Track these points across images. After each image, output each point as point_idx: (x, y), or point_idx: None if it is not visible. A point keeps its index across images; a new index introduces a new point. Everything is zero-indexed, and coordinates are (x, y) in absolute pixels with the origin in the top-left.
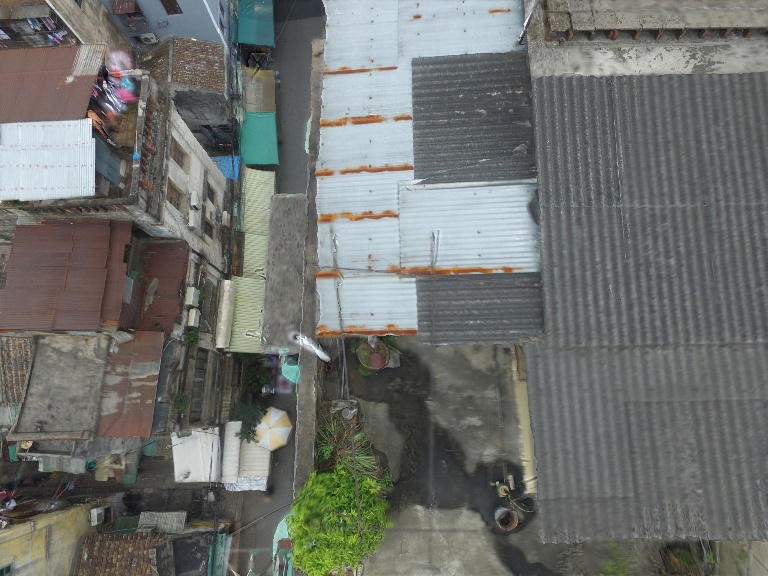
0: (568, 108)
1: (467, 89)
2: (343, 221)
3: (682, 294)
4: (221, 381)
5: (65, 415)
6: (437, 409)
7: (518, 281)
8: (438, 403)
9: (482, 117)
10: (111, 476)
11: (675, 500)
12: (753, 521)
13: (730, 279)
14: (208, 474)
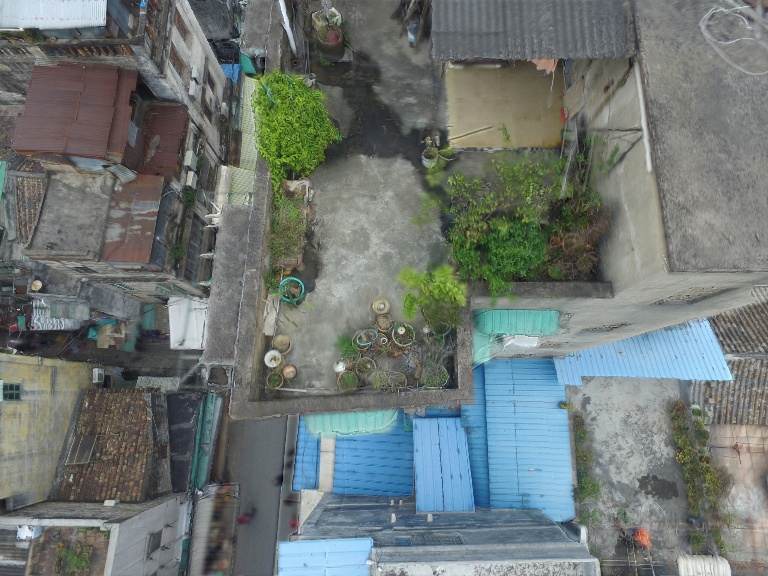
0: None
1: None
2: None
3: None
4: None
5: (73, 239)
6: (381, 92)
7: None
8: (382, 88)
9: None
10: (112, 344)
11: (533, 35)
12: (588, 46)
13: None
14: None
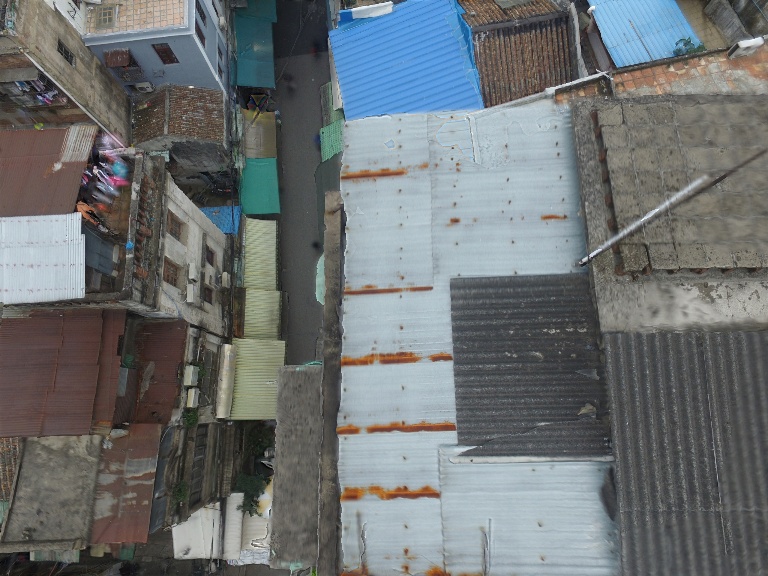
0: (650, 377)
1: (519, 323)
2: (372, 499)
3: None
4: (222, 452)
5: (55, 521)
6: None
7: None
8: None
9: (538, 363)
10: (107, 551)
11: None
12: None
13: None
14: (209, 551)
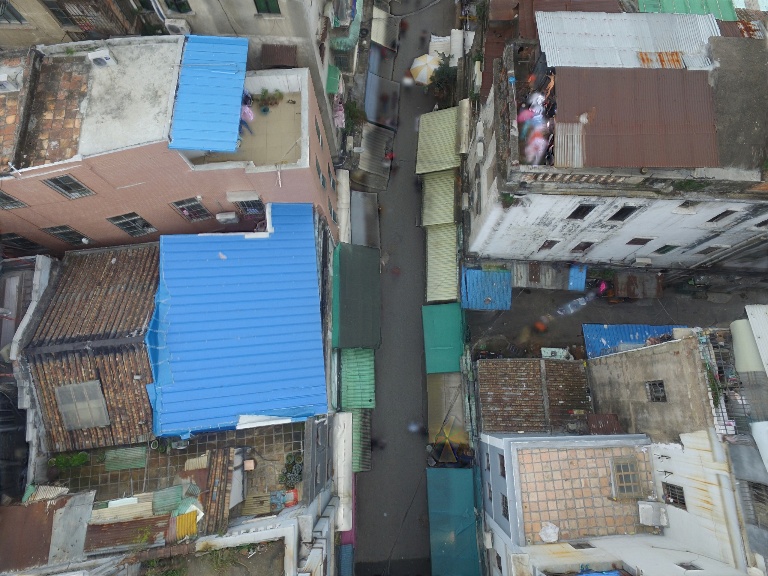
0: None
1: None
2: None
3: None
4: (465, 83)
5: None
6: None
7: None
8: None
9: None
10: None
11: None
12: None
13: None
14: (474, 34)
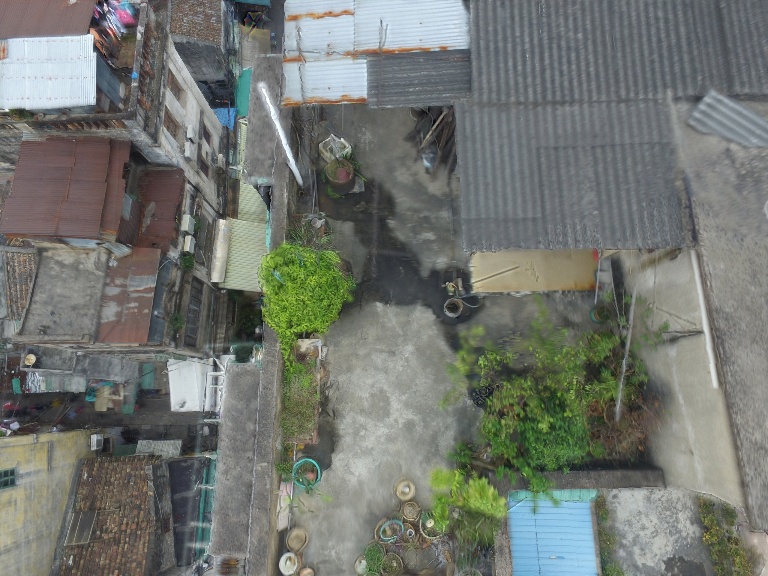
0: None
1: None
2: (307, 20)
3: (588, 63)
4: (216, 315)
5: (67, 321)
6: (396, 226)
7: (452, 57)
8: (397, 222)
9: None
10: (110, 406)
11: (575, 220)
12: (639, 234)
13: (628, 50)
14: (203, 403)
